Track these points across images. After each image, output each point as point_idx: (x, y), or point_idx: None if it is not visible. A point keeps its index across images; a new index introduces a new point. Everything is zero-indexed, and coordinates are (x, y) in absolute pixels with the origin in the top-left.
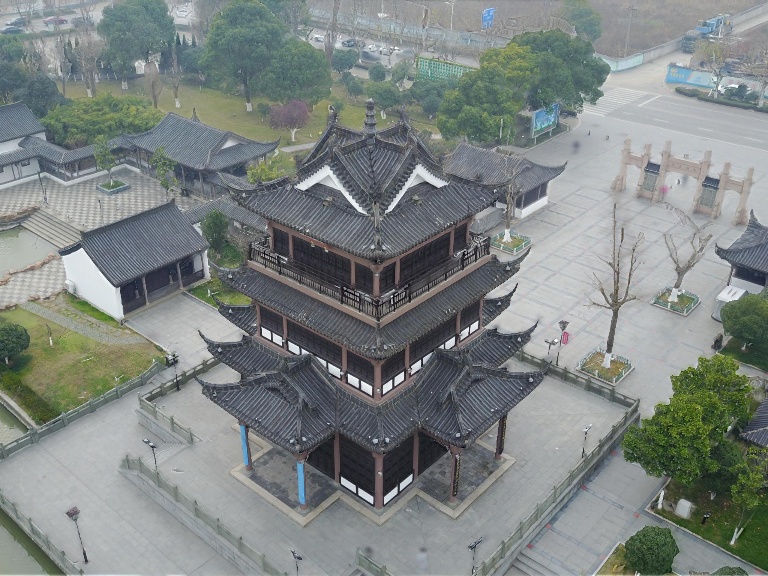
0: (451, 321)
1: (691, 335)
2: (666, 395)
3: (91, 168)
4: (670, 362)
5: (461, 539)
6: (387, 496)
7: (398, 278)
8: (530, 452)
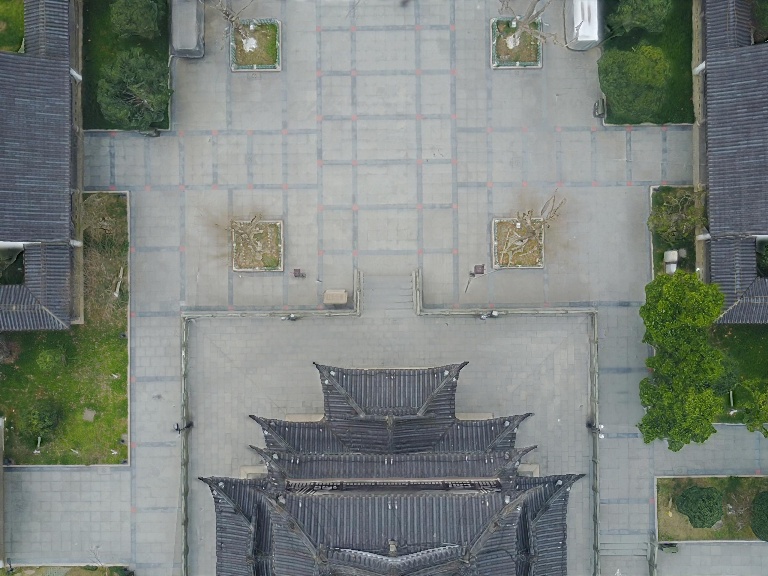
0: None
1: (564, 105)
2: (594, 244)
3: None
4: (569, 179)
5: None
6: None
7: None
8: (541, 444)
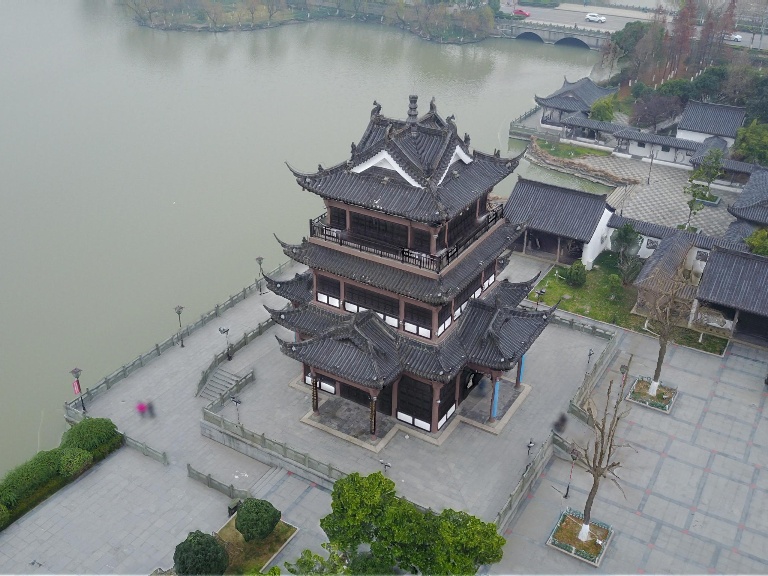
0: (394, 302)
1: None
2: None
3: (727, 181)
4: None
5: (280, 425)
6: (308, 378)
7: (349, 226)
8: (393, 462)
